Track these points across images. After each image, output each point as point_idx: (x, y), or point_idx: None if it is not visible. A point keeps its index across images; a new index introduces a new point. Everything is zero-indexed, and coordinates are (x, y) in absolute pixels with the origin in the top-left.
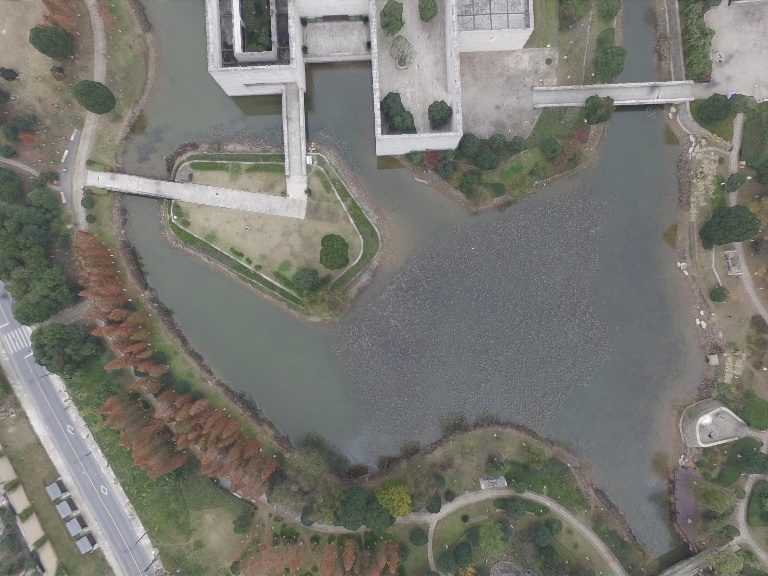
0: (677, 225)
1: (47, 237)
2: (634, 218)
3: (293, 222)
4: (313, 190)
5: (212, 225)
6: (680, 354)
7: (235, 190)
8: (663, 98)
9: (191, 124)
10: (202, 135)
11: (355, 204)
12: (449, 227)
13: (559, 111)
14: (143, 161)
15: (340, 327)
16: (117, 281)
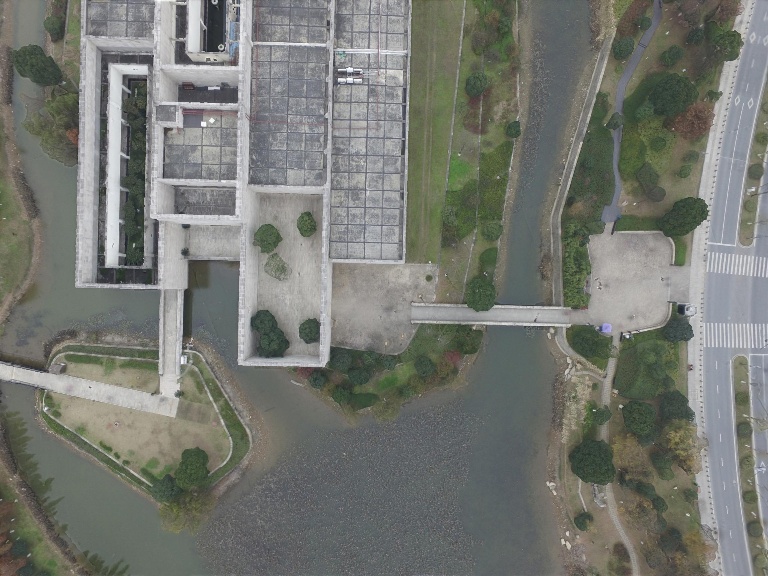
0: (549, 444)
1: None
2: (507, 434)
3: (164, 420)
4: (186, 389)
5: (83, 418)
6: (544, 572)
7: (108, 384)
8: (540, 321)
9: (72, 311)
10: (82, 323)
11: (227, 405)
12: (322, 431)
13: (436, 328)
14: (21, 345)
15: (206, 523)
16: None
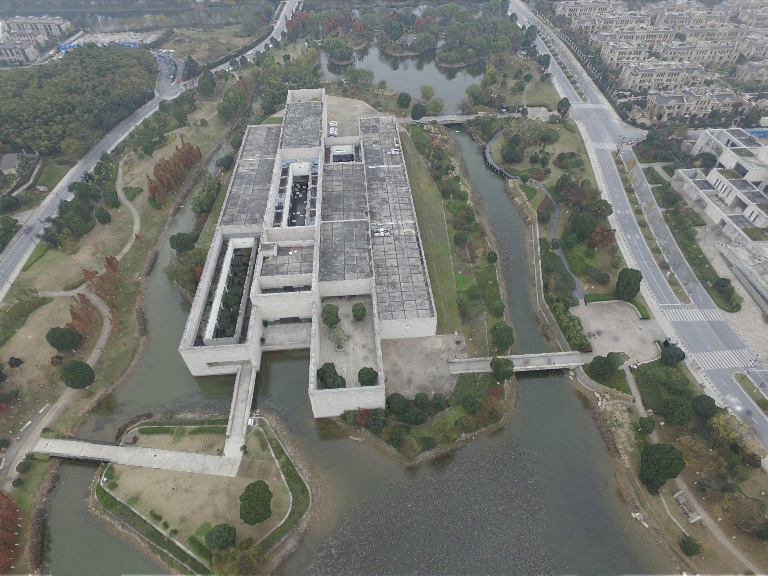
0: (615, 473)
1: None
2: (569, 467)
3: (223, 480)
4: (249, 449)
5: (139, 487)
6: None
7: (174, 451)
8: (558, 364)
9: (153, 399)
10: (160, 407)
11: (289, 461)
12: (383, 483)
13: (473, 376)
14: (97, 430)
15: None
16: (9, 553)
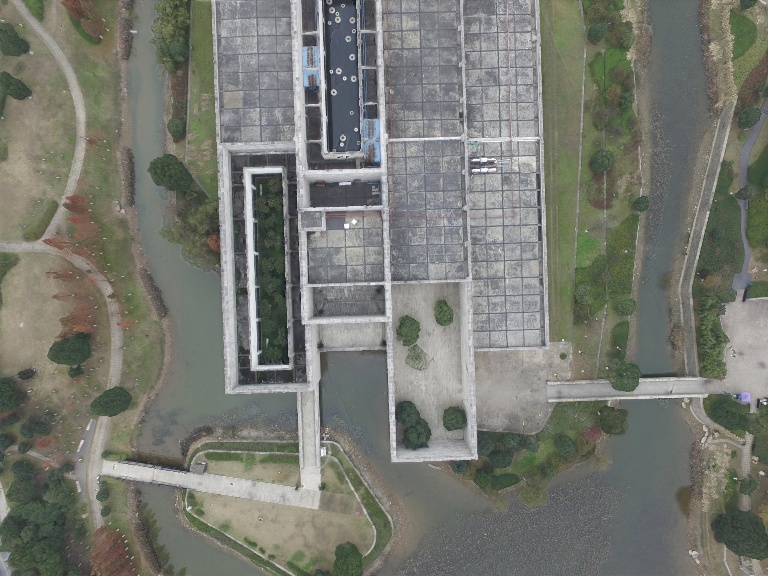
0: (689, 513)
1: (62, 534)
2: (646, 505)
3: (307, 513)
4: (327, 481)
5: (226, 515)
6: None
7: (249, 480)
8: (677, 393)
9: (206, 408)
10: (217, 419)
11: (368, 494)
12: (462, 513)
13: (573, 405)
14: (158, 444)
15: None
16: (131, 574)
